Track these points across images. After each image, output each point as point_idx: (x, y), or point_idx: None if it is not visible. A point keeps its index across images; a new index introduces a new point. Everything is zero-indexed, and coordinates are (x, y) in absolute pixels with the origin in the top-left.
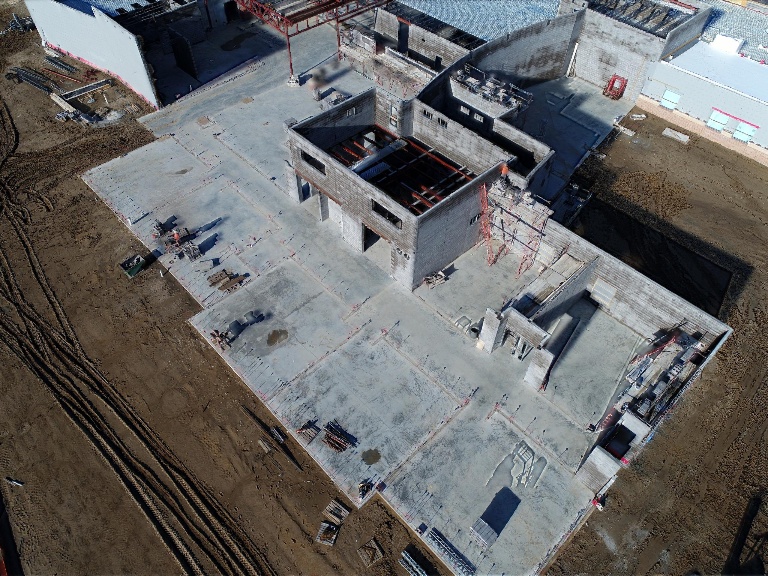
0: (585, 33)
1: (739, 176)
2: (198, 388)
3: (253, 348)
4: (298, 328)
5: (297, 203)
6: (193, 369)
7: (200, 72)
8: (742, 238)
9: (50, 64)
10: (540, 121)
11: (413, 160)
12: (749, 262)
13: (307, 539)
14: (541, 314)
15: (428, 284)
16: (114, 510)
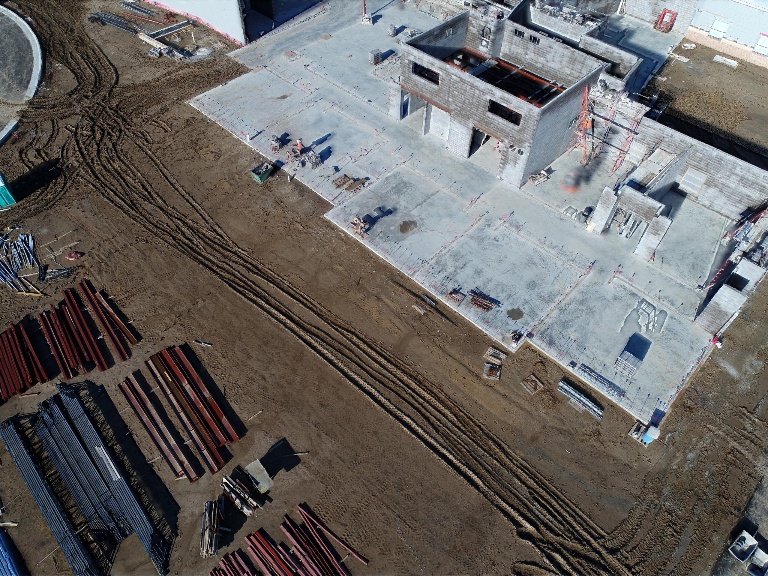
0: None
1: None
2: (347, 268)
3: (389, 235)
4: (425, 219)
5: (397, 121)
6: (339, 253)
7: (275, 14)
8: None
9: (128, 9)
10: None
11: (507, 76)
12: None
13: (475, 376)
14: (651, 191)
15: (534, 181)
16: (299, 361)
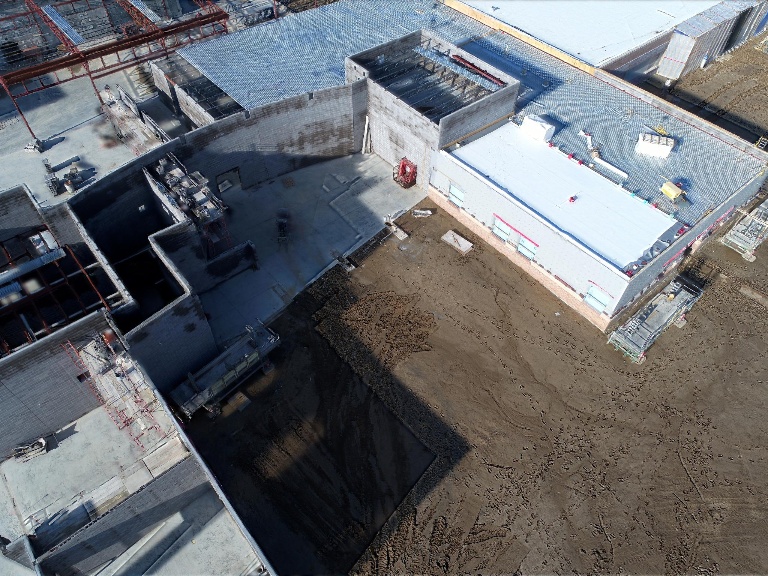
0: (372, 106)
1: (511, 305)
2: None
3: None
4: None
5: None
6: None
7: None
8: (474, 401)
9: None
10: (276, 221)
11: (58, 280)
12: (466, 439)
13: None
14: (67, 547)
15: (15, 458)
16: None
